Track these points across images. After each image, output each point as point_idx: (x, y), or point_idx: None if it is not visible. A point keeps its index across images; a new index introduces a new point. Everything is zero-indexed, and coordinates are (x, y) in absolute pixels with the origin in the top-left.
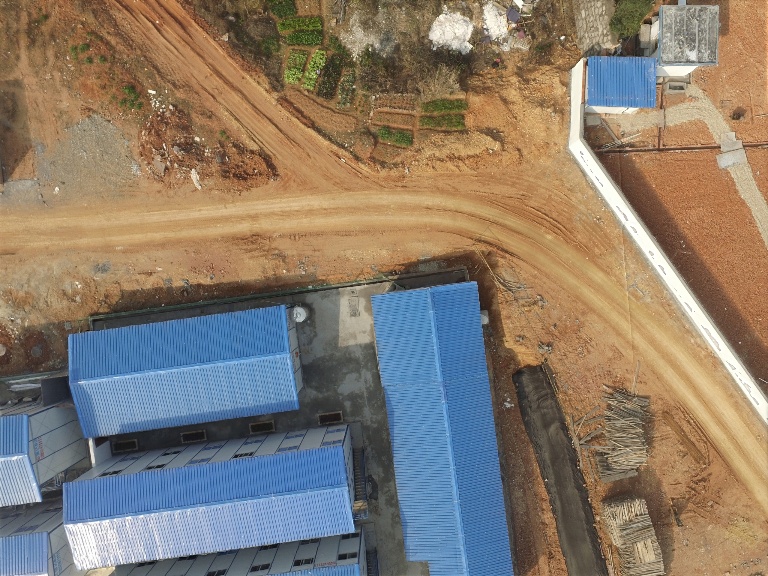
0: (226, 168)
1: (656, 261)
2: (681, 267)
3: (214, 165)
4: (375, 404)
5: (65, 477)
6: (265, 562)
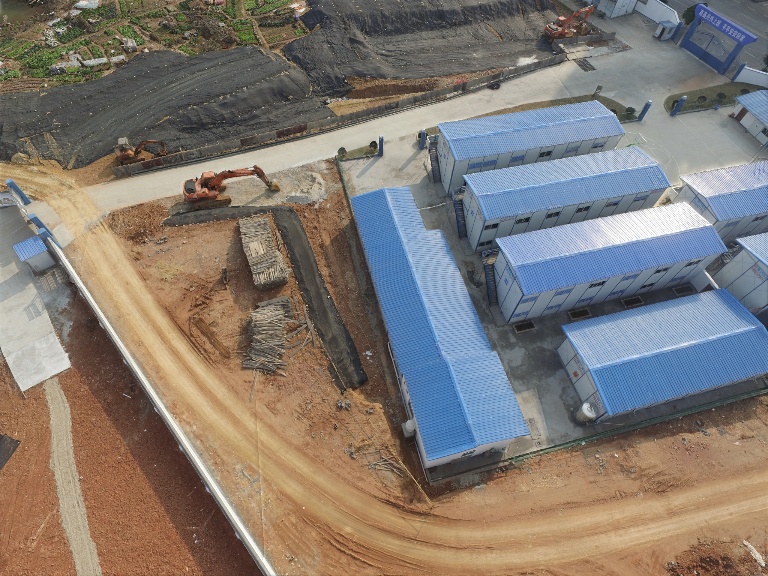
0: (730, 572)
1: (231, 511)
2: (200, 509)
3: (745, 573)
4: (489, 342)
5: (723, 260)
6: (549, 219)
